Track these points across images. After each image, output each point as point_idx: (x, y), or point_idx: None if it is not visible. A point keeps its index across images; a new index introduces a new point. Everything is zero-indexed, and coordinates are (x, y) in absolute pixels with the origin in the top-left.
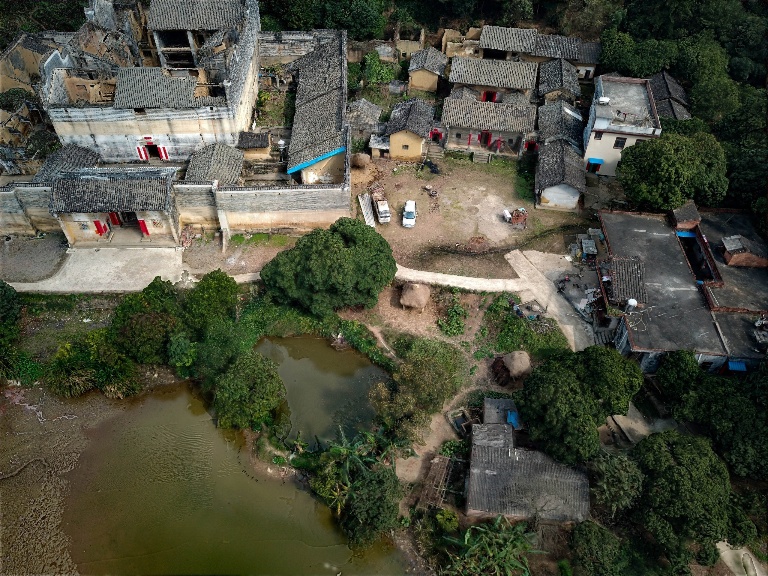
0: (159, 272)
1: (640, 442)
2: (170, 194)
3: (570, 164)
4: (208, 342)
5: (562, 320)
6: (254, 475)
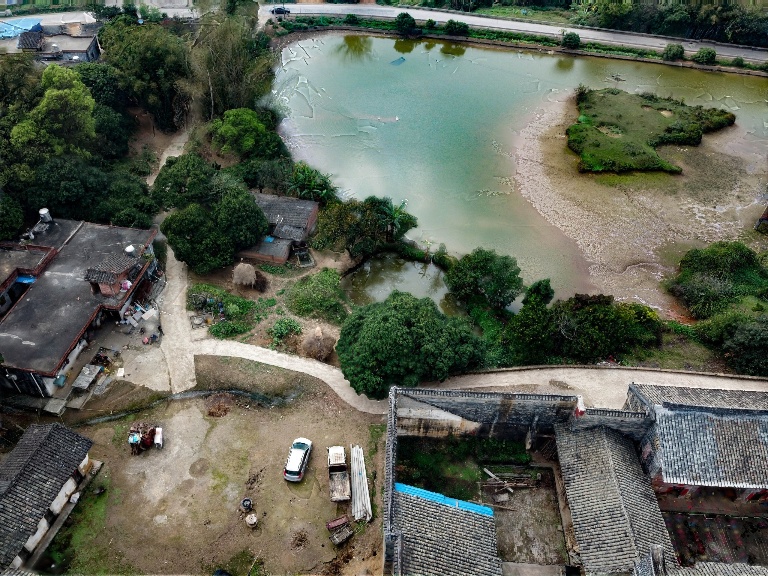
0: (614, 393)
1: (199, 193)
2: (639, 404)
3: (8, 478)
4: (515, 272)
5: (179, 309)
6: (459, 255)
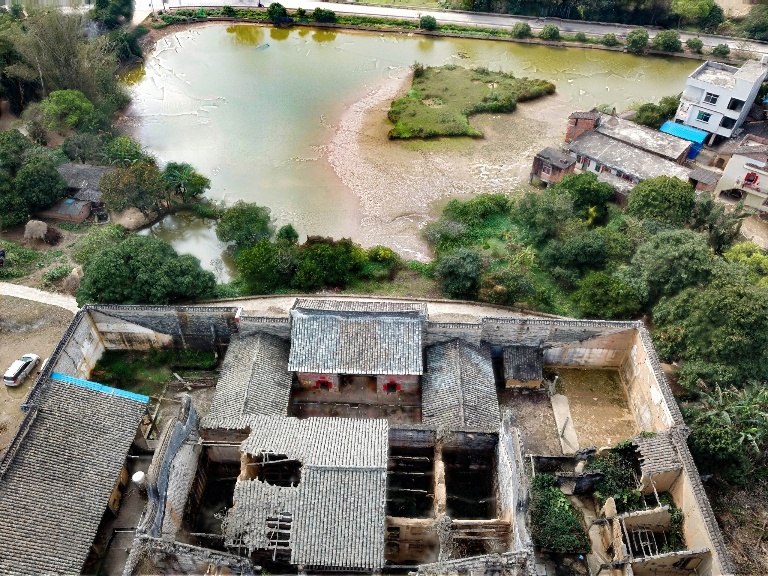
0: None
1: (10, 163)
2: None
3: None
4: (261, 219)
5: None
6: None
